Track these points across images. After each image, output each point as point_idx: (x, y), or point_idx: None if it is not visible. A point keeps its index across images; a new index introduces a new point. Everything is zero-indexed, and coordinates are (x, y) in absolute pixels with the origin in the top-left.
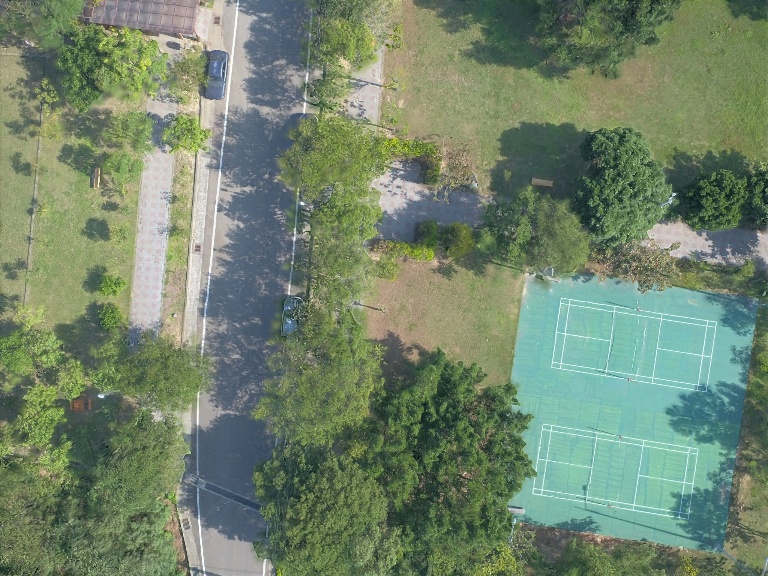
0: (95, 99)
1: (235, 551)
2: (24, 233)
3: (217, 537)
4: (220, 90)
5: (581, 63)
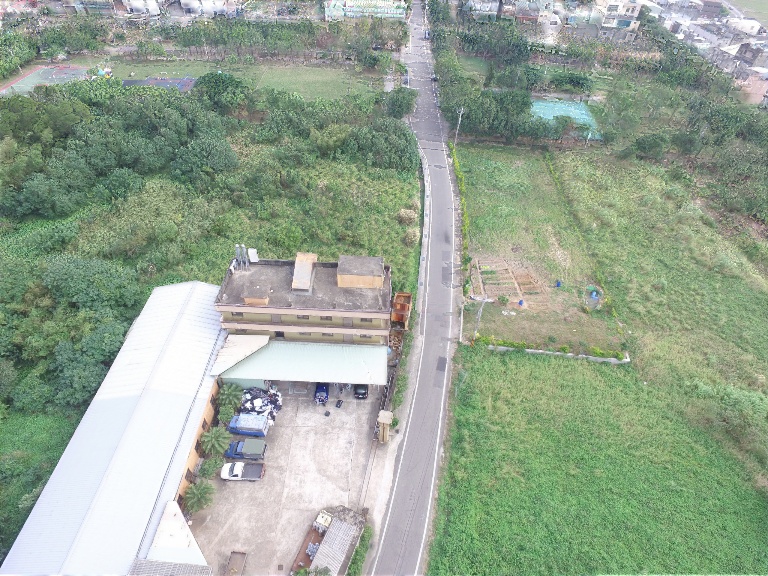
0: (373, 65)
1: (431, 143)
2: (346, 91)
3: (424, 141)
4: (407, 74)
5: (509, 65)
